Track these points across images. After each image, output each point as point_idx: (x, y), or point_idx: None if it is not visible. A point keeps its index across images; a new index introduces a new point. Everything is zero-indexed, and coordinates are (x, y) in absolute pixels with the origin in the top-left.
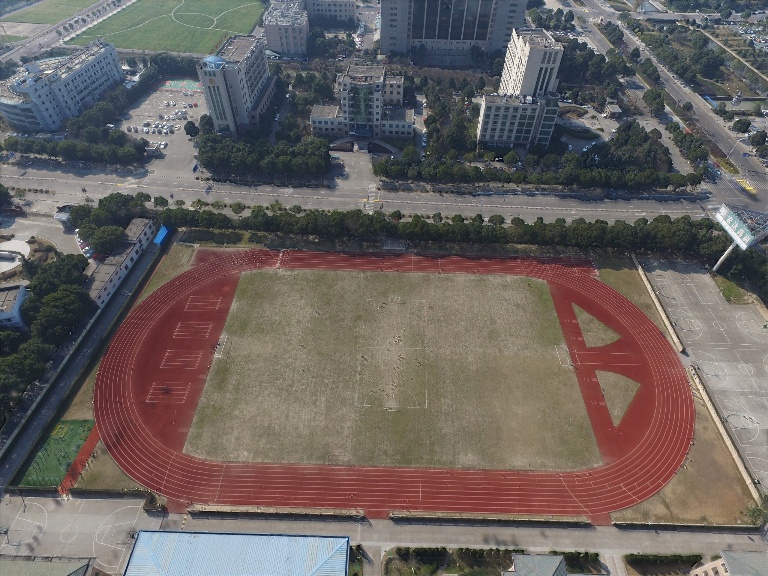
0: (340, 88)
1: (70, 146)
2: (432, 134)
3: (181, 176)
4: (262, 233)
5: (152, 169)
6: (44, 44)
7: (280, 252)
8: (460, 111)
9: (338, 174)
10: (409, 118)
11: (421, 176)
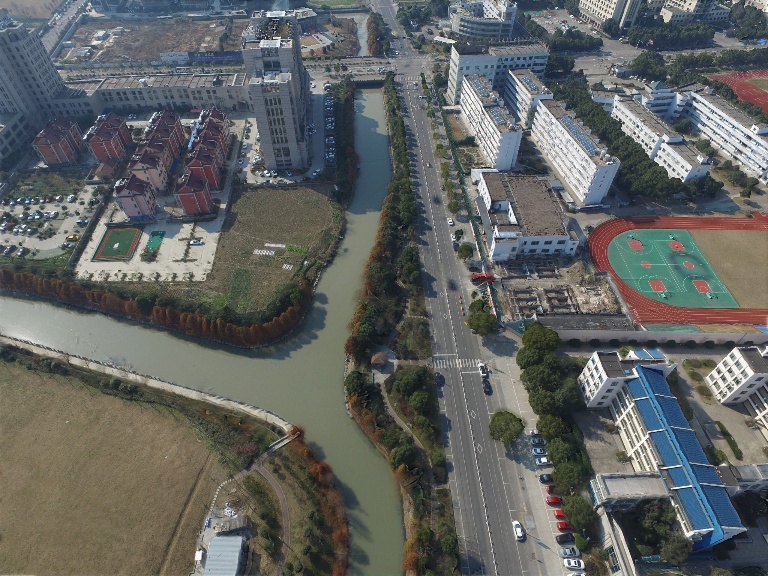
0: (653, 1)
1: (565, 40)
2: (743, 16)
3: (631, 52)
4: (724, 67)
5: (608, 51)
6: (384, 2)
7: (748, 72)
8: (738, 4)
9: (713, 41)
10: (726, 8)
11: (761, 36)
